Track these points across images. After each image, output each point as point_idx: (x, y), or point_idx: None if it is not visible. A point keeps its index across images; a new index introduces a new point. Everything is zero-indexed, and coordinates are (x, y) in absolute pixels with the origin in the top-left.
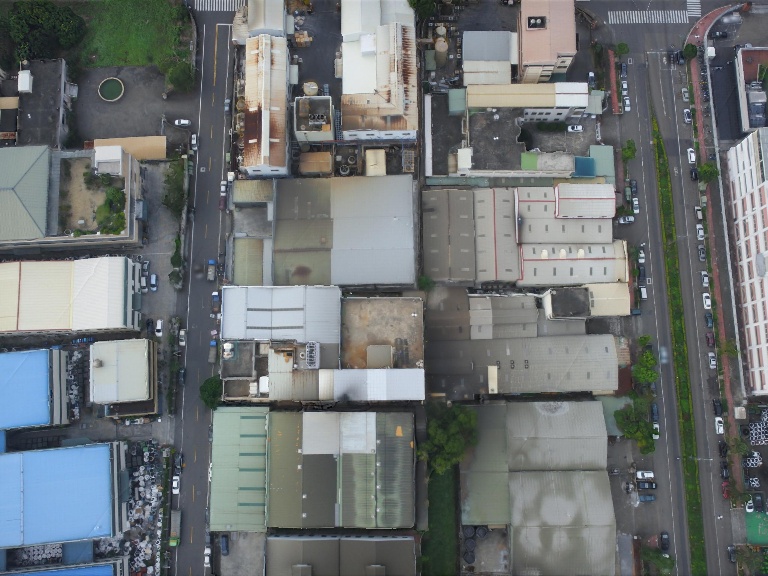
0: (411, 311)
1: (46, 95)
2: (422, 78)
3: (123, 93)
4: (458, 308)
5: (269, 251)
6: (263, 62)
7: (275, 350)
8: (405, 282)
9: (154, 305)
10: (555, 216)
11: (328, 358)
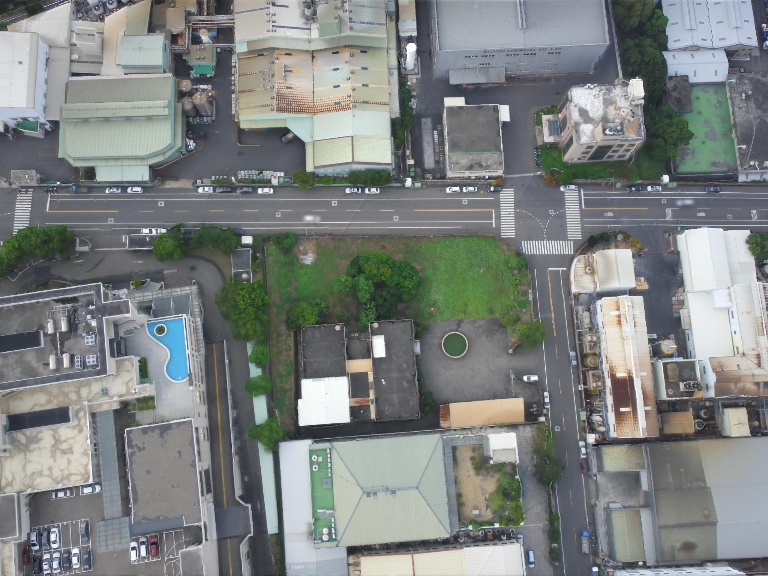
0: None
1: (398, 358)
2: None
3: (467, 348)
4: None
5: (647, 523)
6: (628, 326)
7: None
8: None
9: None
10: None
11: None
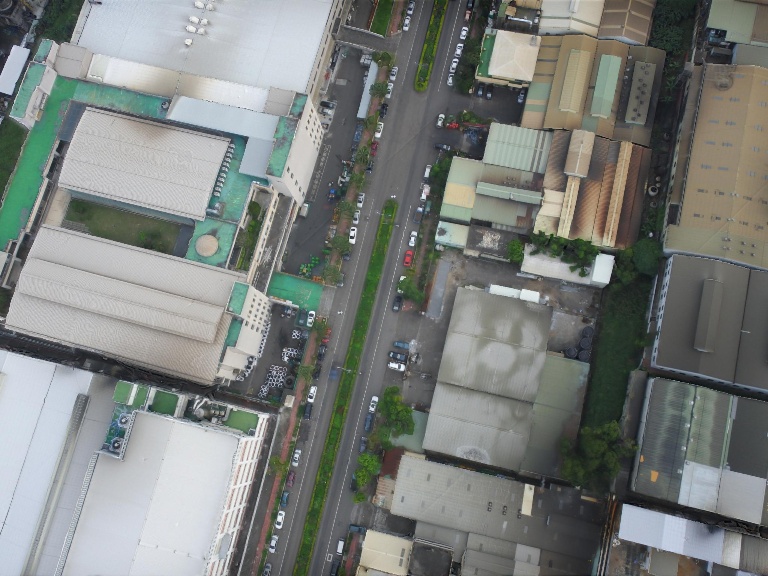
0: None
1: None
2: None
3: None
4: None
5: None
6: None
7: None
8: None
9: None
10: None
11: None
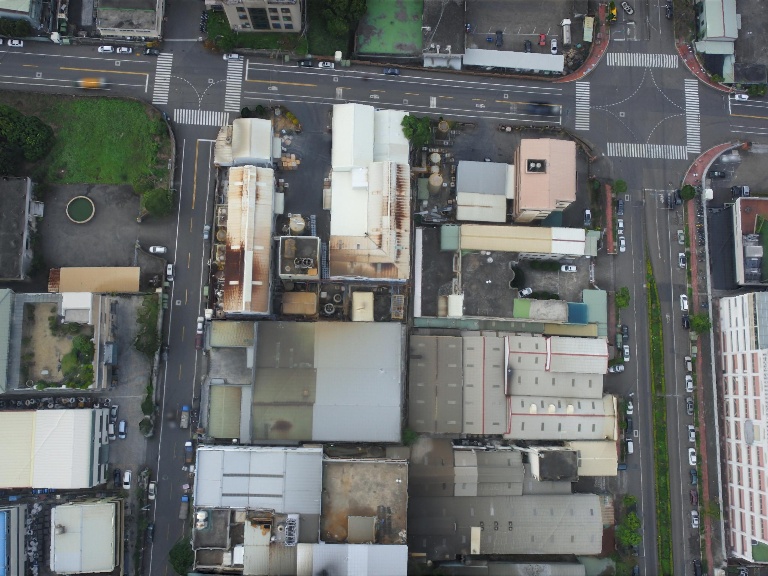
0: (395, 477)
1: (8, 217)
2: (414, 210)
3: (94, 214)
4: (443, 463)
5: (247, 400)
6: (247, 197)
7: (252, 522)
8: (390, 440)
9: (122, 453)
10: (546, 369)
11: (307, 530)
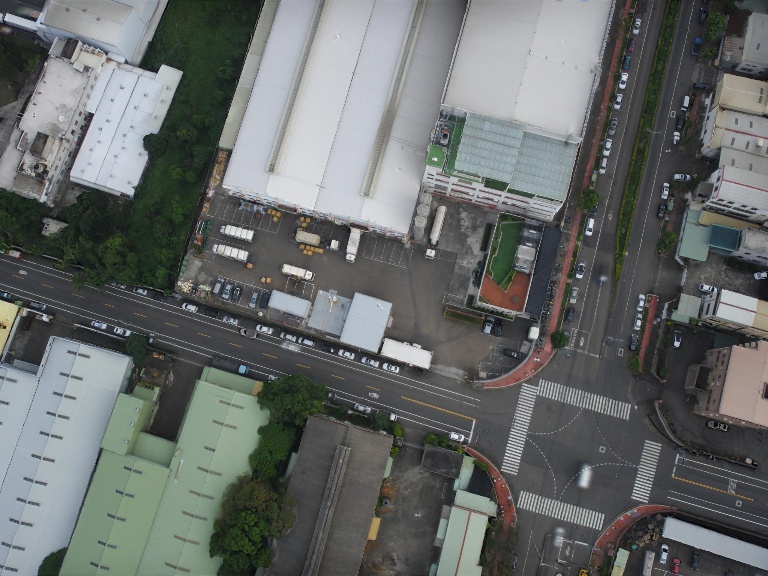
0: None
1: None
2: None
3: None
4: None
5: None
6: None
7: None
8: None
9: None
10: None
11: None
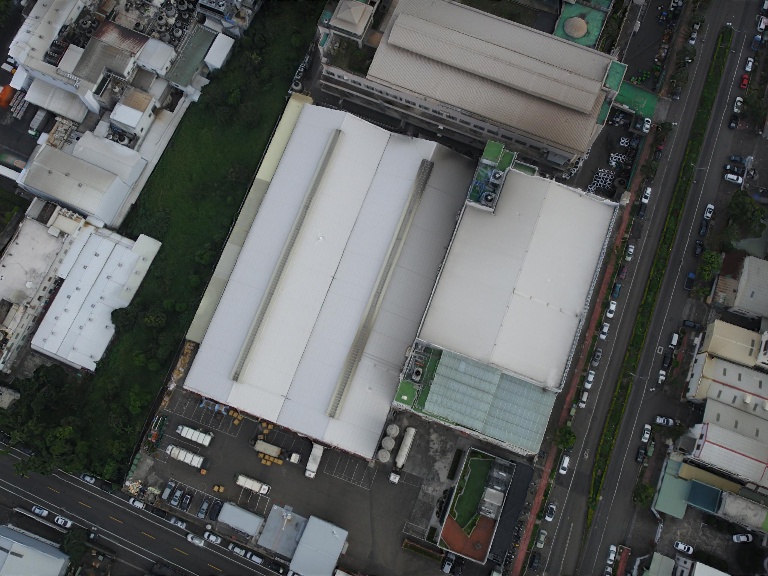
0: None
1: None
2: None
3: None
4: None
5: None
6: None
7: None
8: None
9: None
10: None
11: None
